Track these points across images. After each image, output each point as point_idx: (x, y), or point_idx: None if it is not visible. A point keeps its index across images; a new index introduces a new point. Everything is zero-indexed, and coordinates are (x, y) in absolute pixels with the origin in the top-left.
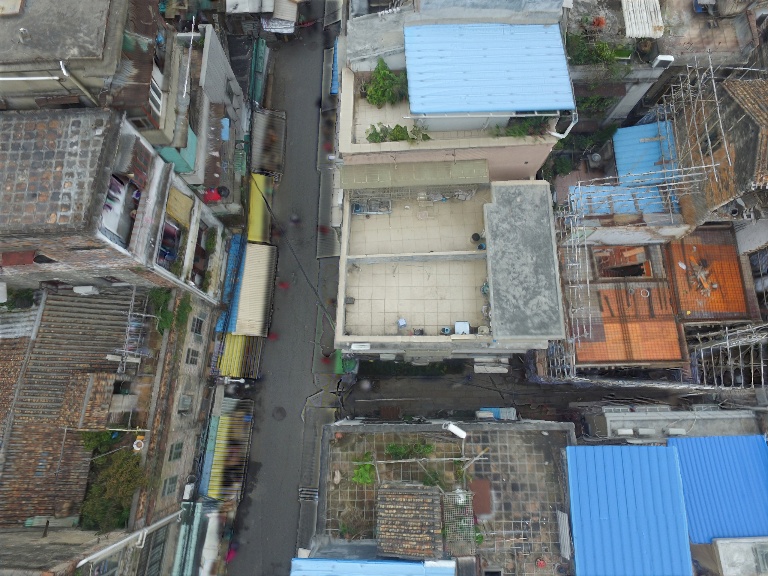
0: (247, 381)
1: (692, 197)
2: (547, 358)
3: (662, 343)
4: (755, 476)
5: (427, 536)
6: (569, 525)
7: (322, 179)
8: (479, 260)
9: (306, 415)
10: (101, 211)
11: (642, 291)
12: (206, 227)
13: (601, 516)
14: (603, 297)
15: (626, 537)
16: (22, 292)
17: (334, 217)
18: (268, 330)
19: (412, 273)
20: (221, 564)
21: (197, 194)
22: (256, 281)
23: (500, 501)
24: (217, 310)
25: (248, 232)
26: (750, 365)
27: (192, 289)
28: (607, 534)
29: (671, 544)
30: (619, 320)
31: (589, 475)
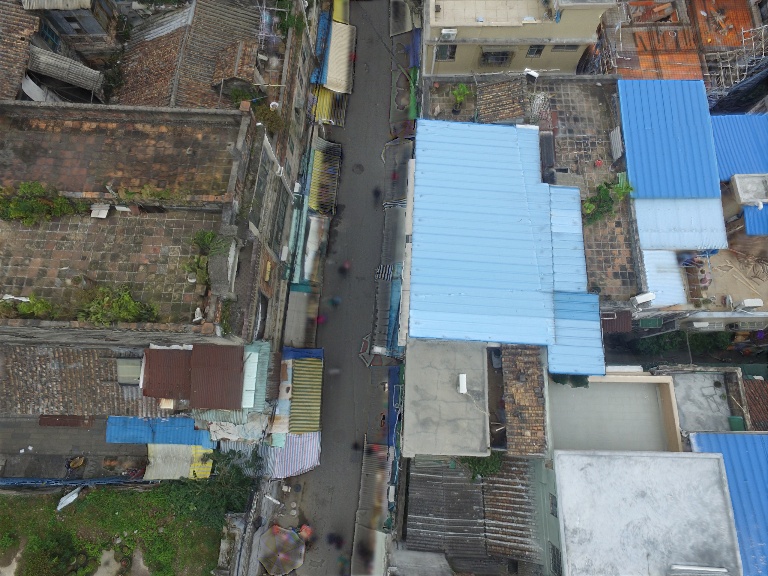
0: (331, 141)
1: None
2: None
3: (687, 69)
4: (765, 140)
5: (518, 105)
6: (621, 132)
7: None
8: None
9: (386, 152)
10: None
11: (670, 32)
12: None
13: (645, 127)
14: (638, 37)
15: (665, 140)
16: None
17: None
18: None
19: None
20: (321, 257)
21: None
22: (340, 51)
23: (565, 128)
24: (313, 61)
25: (333, 11)
26: (761, 43)
27: (304, 13)
28: (650, 138)
29: (700, 145)
30: (651, 53)
31: (636, 99)
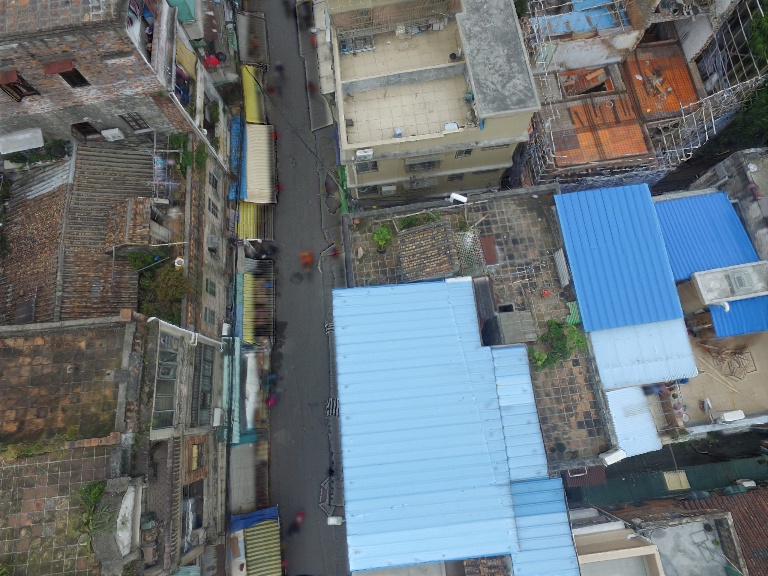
0: (263, 252)
1: (637, 4)
2: (531, 167)
3: (630, 143)
4: (721, 224)
5: (444, 257)
6: (565, 256)
7: (306, 64)
8: (458, 76)
9: (322, 264)
10: (127, 10)
11: (607, 103)
12: (208, 101)
13: (591, 246)
14: (573, 112)
15: (614, 259)
16: (55, 141)
17: (323, 86)
18: (276, 197)
19: (401, 95)
20: (264, 397)
21: (198, 55)
22: (259, 156)
23: (504, 254)
24: (228, 177)
25: (246, 113)
26: (703, 123)
27: (205, 140)
28: (598, 259)
29: (653, 259)
30: (590, 129)
31: (576, 215)
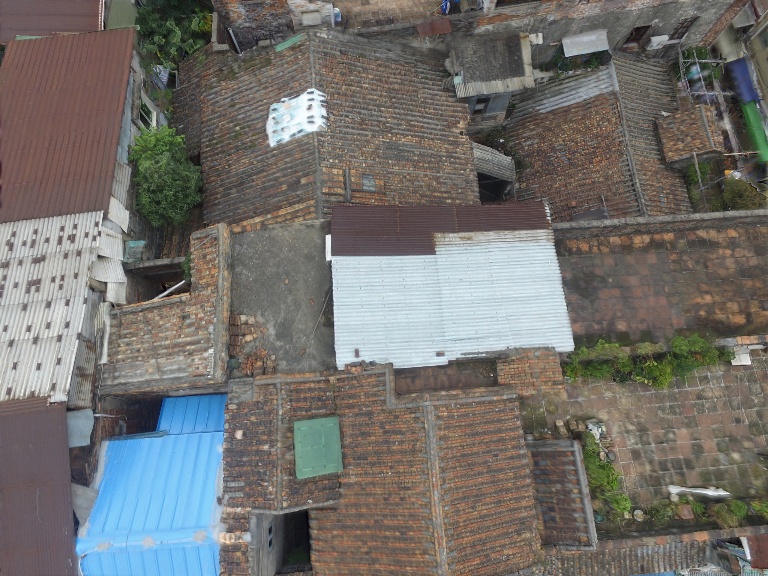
0: None
1: None
2: None
3: None
4: None
5: None
6: None
7: None
8: None
9: None
10: None
11: None
12: None
13: None
14: None
15: None
16: None
17: (735, 19)
18: None
19: None
20: None
21: None
22: None
23: None
24: None
25: None
26: None
27: None
28: None
29: None
30: None
31: None
